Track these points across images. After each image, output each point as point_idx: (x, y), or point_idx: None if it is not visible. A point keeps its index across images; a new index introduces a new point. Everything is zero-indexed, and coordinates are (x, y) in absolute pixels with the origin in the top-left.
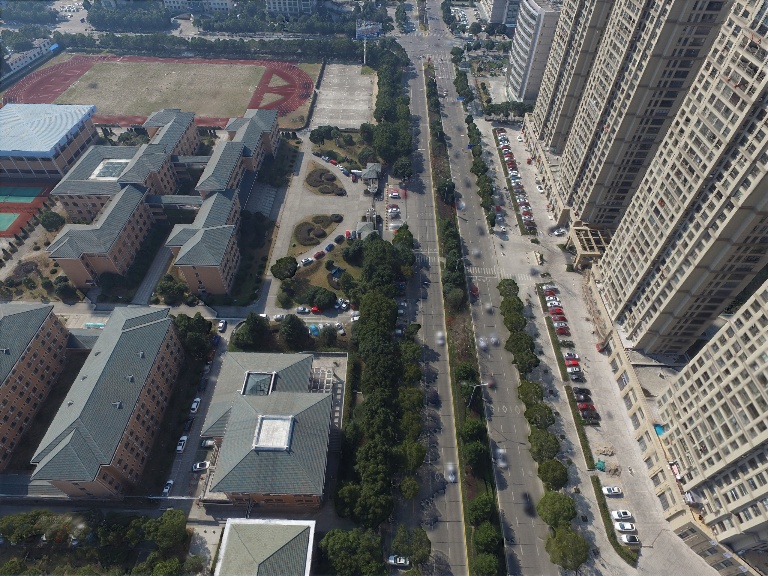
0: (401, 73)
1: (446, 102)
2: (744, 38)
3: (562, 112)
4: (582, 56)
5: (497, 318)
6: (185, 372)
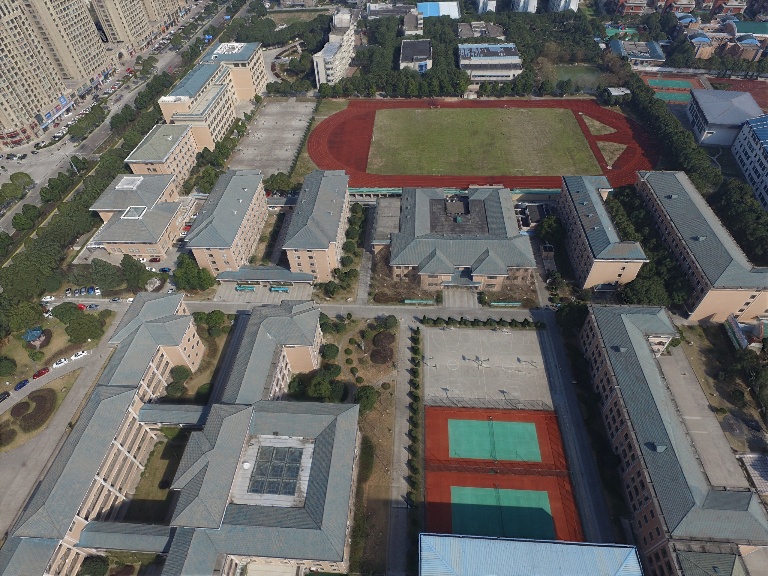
0: None
1: None
2: None
3: None
4: None
5: None
6: None
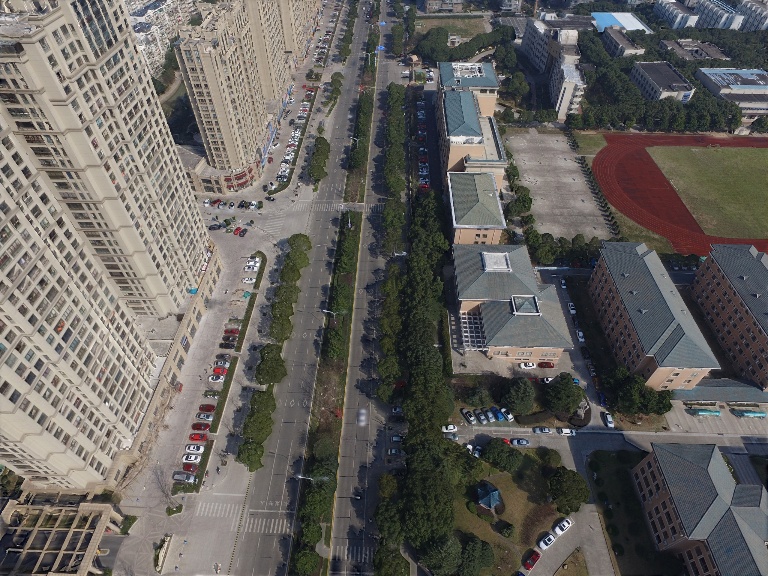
0: None
1: None
2: None
3: None
4: None
5: (276, 435)
6: None
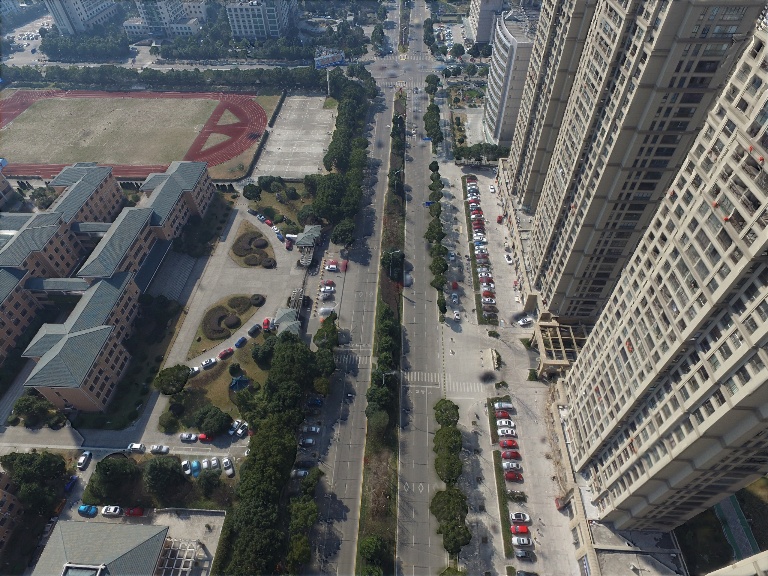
0: (365, 107)
1: (413, 141)
2: (738, 147)
3: (533, 168)
4: (553, 105)
5: (431, 451)
6: (19, 535)
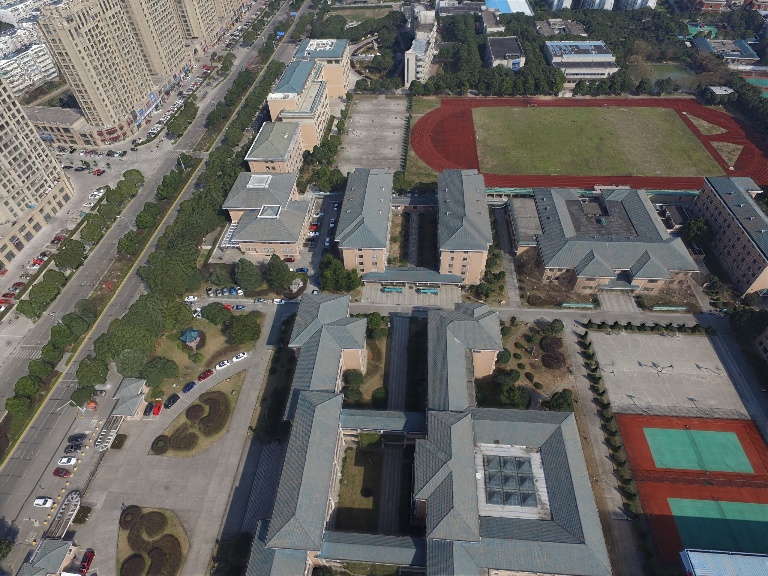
0: None
1: None
2: None
3: None
4: None
5: (62, 302)
6: None
